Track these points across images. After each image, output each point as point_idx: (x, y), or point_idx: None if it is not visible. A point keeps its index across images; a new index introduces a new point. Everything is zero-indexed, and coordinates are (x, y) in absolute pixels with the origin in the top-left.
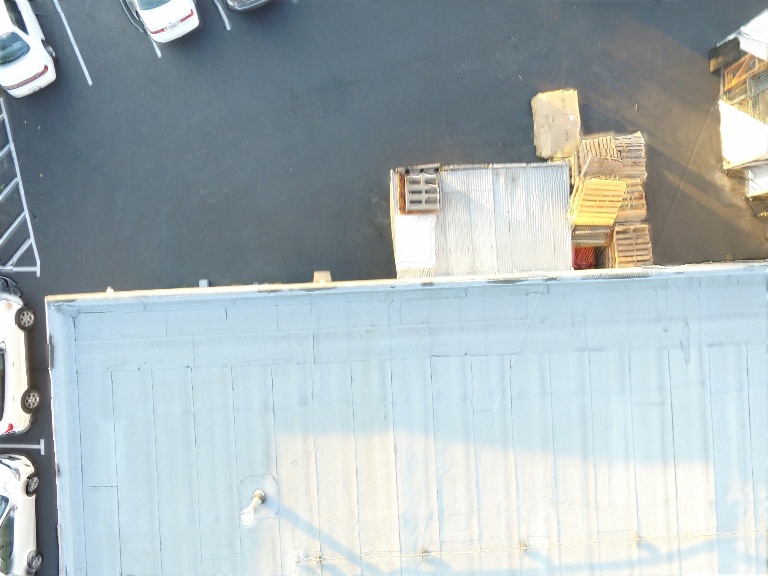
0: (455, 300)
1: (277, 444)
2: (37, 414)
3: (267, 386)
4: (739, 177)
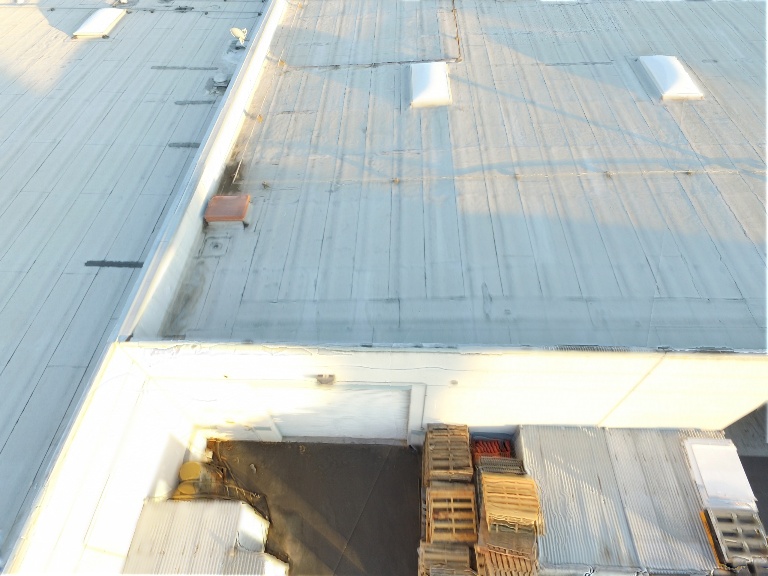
0: (739, 348)
1: None
2: None
3: None
4: (274, 551)
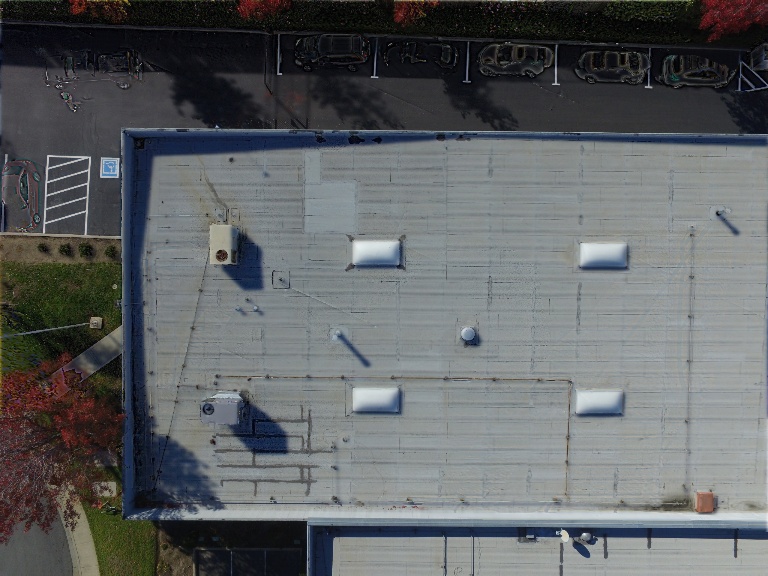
0: None
1: (737, 221)
2: (665, 85)
3: (761, 219)
4: None
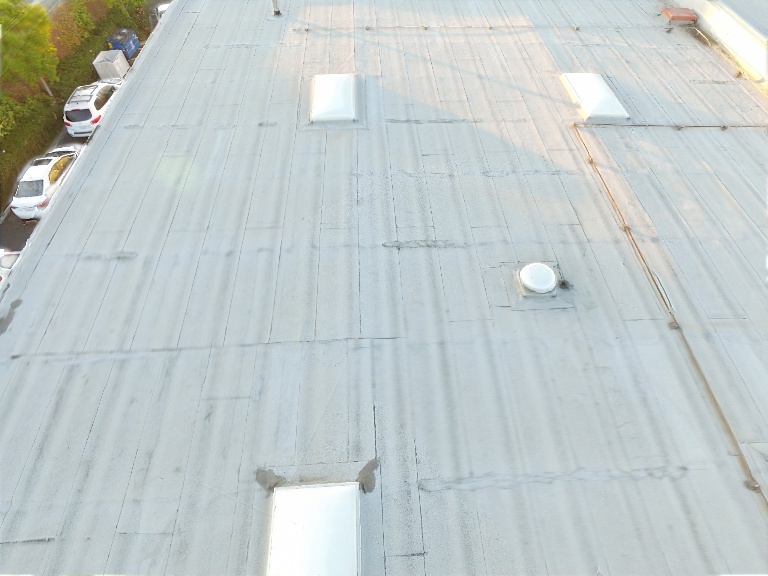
0: None
1: None
2: None
3: None
4: None
